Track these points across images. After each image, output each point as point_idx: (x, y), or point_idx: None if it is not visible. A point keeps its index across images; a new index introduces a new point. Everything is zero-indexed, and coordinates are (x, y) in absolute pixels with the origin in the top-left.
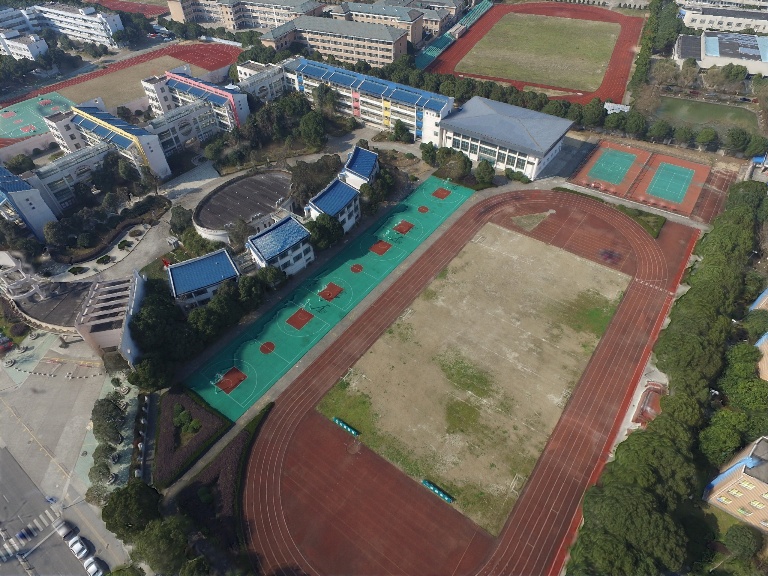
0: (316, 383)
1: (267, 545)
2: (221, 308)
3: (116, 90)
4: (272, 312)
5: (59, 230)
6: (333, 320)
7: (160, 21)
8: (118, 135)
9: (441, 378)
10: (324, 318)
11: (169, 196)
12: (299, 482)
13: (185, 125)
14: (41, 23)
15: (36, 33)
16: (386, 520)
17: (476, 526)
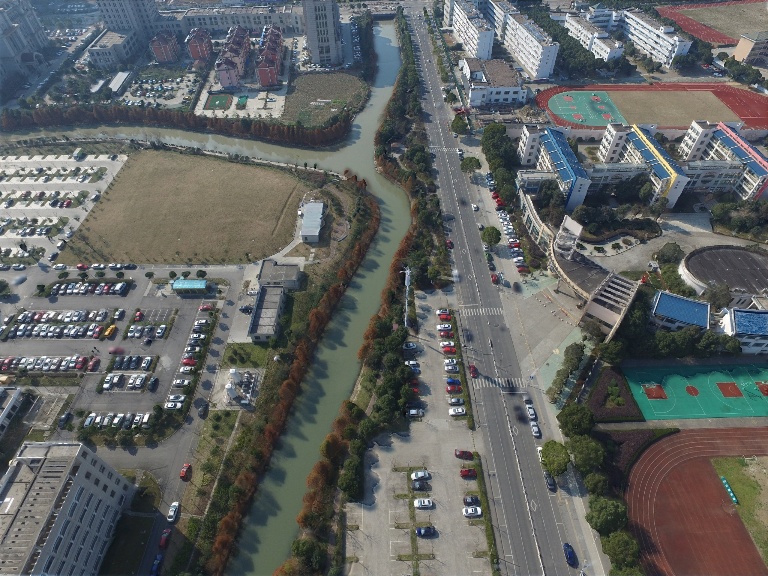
0: (720, 444)
1: (636, 506)
2: (682, 343)
3: (653, 110)
4: (708, 368)
5: (585, 214)
6: (759, 411)
7: (721, 55)
8: (660, 165)
9: None
10: (752, 404)
11: (662, 226)
12: (675, 492)
13: (710, 176)
14: (618, 24)
15: (611, 32)
16: (730, 571)
17: None
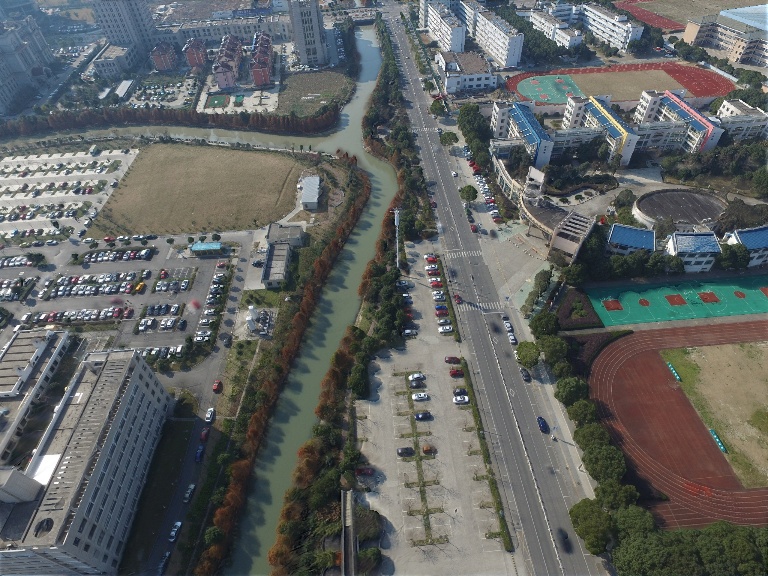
0: (667, 339)
1: (597, 388)
2: (633, 263)
3: (611, 87)
4: (658, 285)
5: (550, 171)
6: (700, 314)
7: (672, 38)
8: (614, 127)
9: (765, 394)
10: (694, 309)
11: (619, 180)
12: (629, 376)
13: (659, 135)
14: (579, 17)
15: (572, 25)
16: (673, 428)
17: (734, 473)
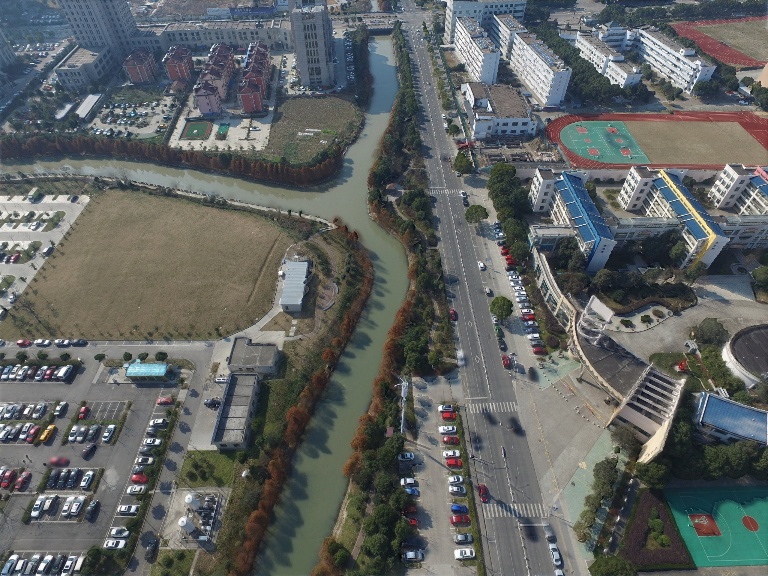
0: None
1: None
2: (738, 464)
3: (676, 144)
4: (767, 491)
5: (610, 280)
6: None
7: (746, 80)
8: (695, 221)
9: None
10: None
11: (697, 292)
12: None
13: (750, 232)
14: (633, 44)
15: (625, 52)
16: None
17: None
